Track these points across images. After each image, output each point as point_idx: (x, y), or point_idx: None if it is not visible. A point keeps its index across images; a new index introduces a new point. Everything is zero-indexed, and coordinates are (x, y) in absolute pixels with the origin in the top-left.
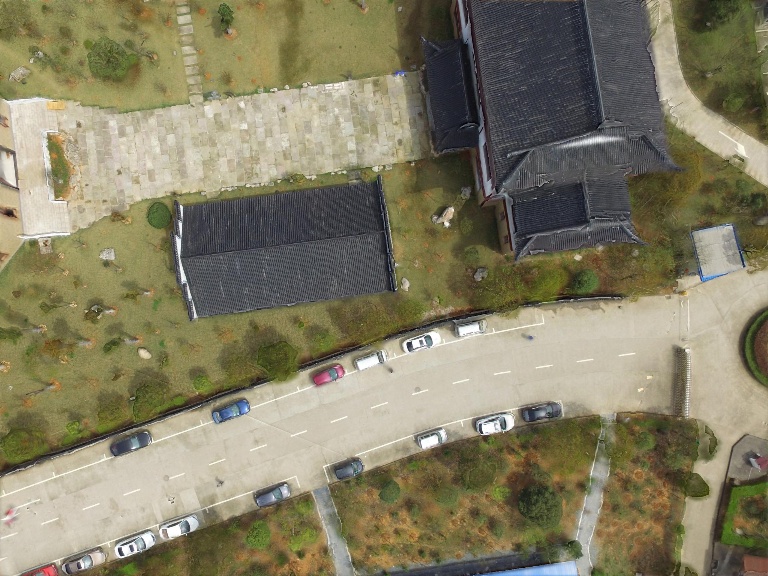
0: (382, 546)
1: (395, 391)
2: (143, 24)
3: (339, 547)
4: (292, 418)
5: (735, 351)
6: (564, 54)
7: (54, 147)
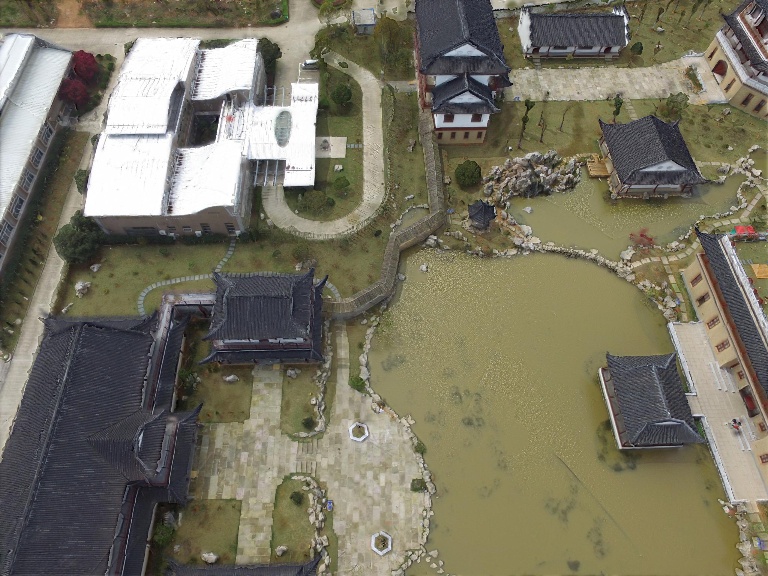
0: None
1: (514, 2)
2: None
3: None
4: None
5: (354, 1)
6: (466, 7)
7: (698, 85)
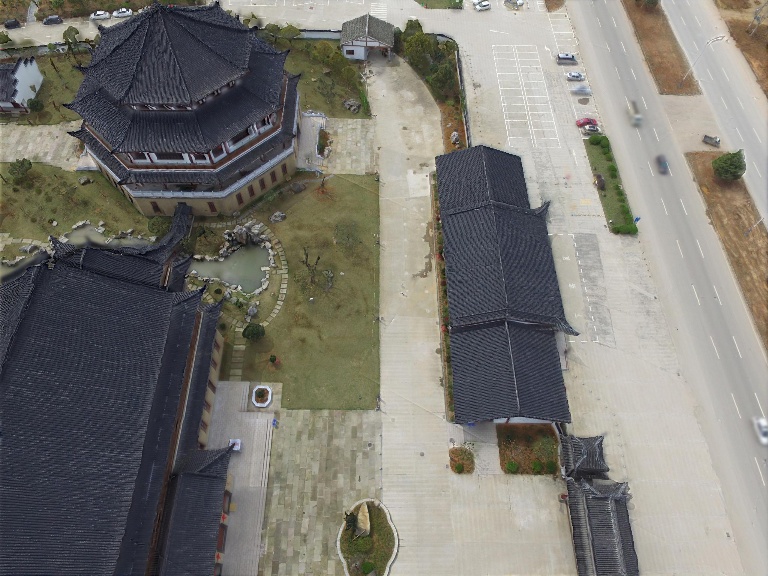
0: (15, 2)
1: None
2: (3, 201)
3: (34, 4)
4: (28, 43)
5: None
6: None
7: None
